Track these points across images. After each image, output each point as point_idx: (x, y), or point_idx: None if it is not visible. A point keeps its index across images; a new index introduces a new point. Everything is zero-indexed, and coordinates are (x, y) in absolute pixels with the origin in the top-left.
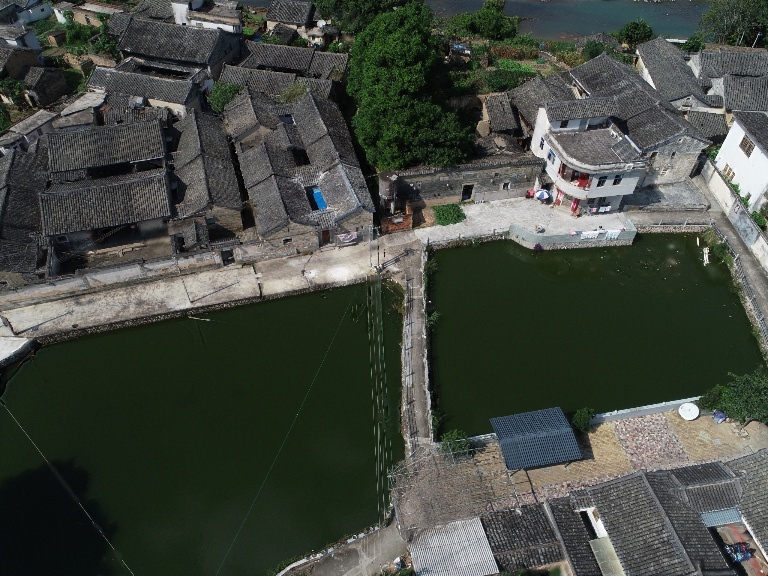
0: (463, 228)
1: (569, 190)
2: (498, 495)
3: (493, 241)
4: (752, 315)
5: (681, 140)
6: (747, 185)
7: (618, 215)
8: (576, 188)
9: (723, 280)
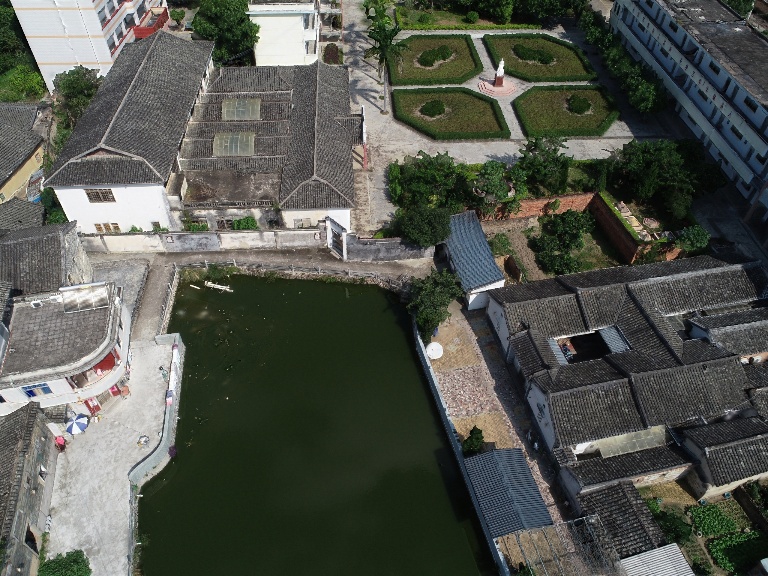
0: (105, 557)
1: (107, 385)
2: (590, 537)
3: (139, 513)
4: (308, 275)
5: (66, 244)
6: (143, 219)
7: (135, 347)
8: (111, 375)
9: (255, 283)
